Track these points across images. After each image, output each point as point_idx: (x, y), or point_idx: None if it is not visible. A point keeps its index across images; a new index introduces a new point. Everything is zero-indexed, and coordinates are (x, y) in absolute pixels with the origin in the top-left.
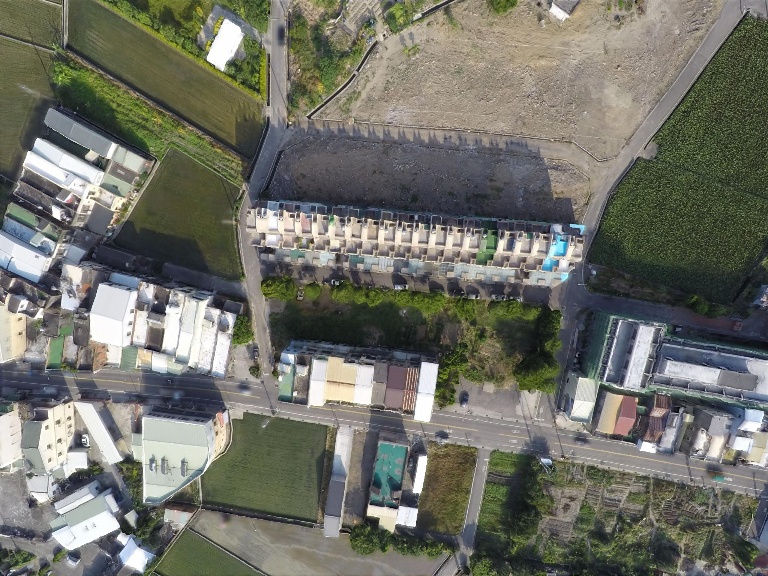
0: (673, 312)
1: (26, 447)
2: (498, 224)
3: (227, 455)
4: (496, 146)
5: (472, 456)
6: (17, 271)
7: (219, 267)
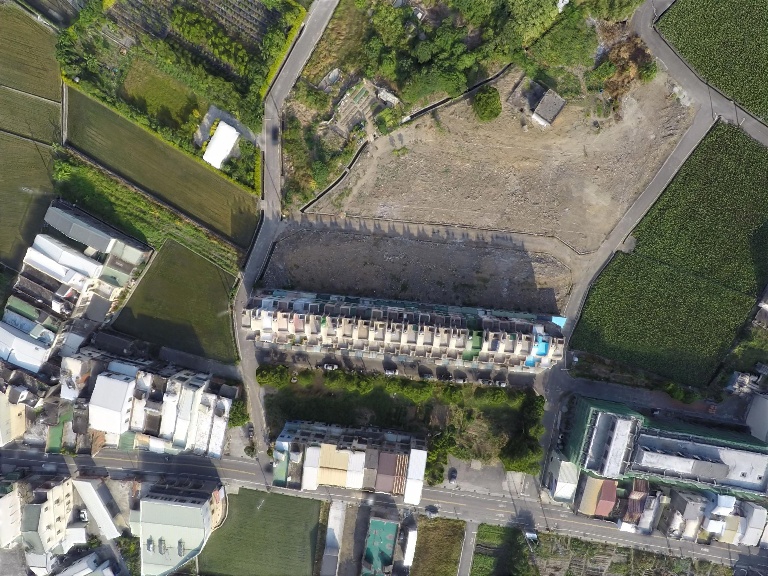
0: (651, 395)
1: (26, 530)
2: (483, 323)
3: (223, 528)
4: (482, 240)
5: (461, 529)
6: (17, 362)
7: (215, 351)
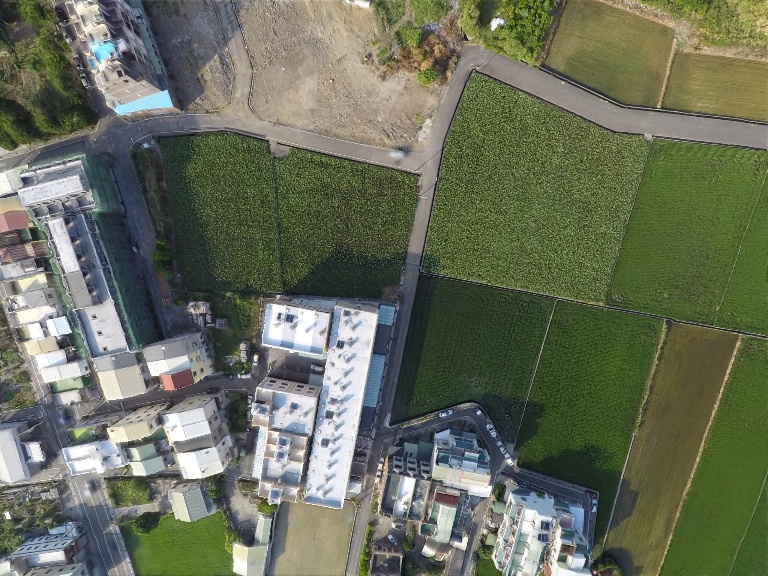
0: (152, 241)
1: None
2: None
3: None
4: None
5: None
6: None
7: None
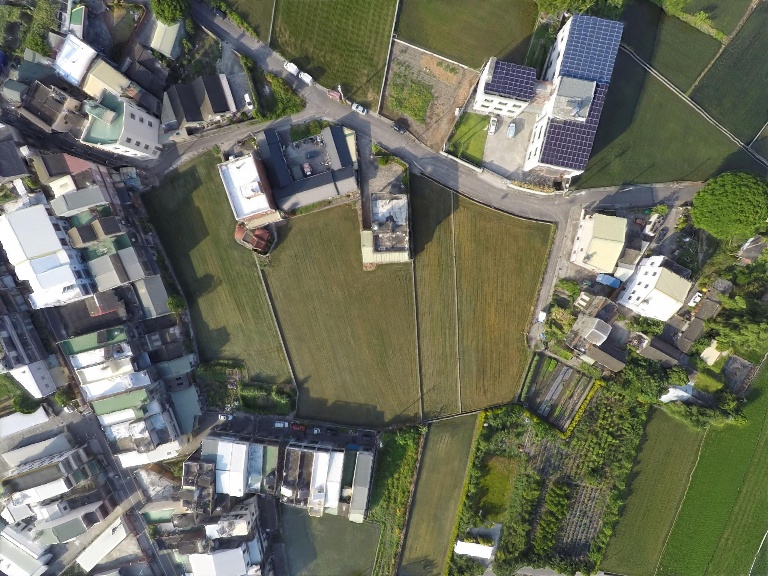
0: None
1: (55, 533)
2: None
3: None
4: None
5: None
6: (219, 477)
7: None
